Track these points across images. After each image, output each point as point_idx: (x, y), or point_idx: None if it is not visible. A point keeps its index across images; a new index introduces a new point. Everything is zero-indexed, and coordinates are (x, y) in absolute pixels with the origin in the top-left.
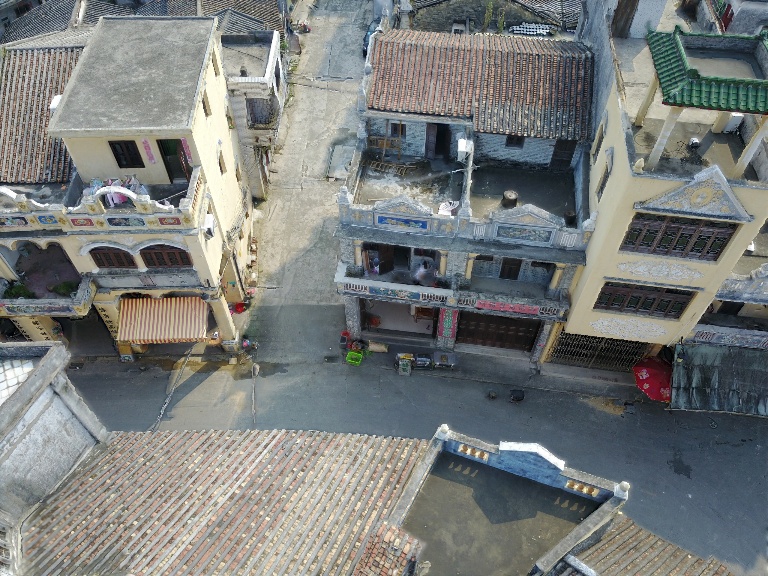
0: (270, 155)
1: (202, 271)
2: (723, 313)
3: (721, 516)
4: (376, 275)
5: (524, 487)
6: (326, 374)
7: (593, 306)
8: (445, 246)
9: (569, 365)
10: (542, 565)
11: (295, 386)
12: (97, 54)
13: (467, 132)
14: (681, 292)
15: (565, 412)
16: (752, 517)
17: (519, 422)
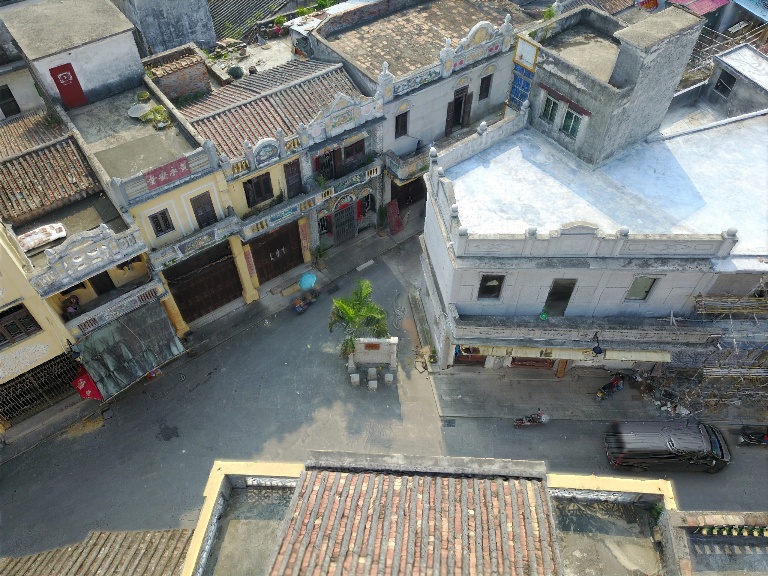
0: None
1: None
2: (103, 293)
3: (213, 448)
4: None
5: None
6: None
7: None
8: None
9: (32, 416)
10: None
11: None
12: None
13: None
14: (12, 310)
15: (47, 461)
16: (237, 430)
17: (3, 505)
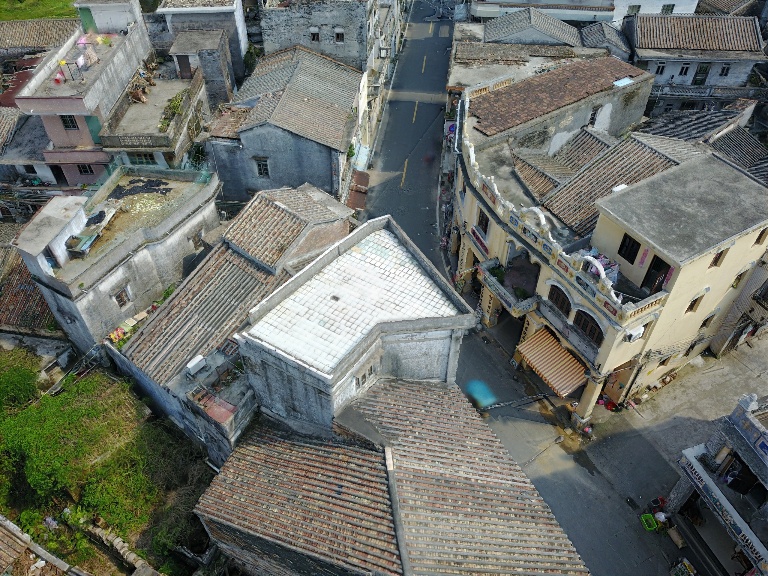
0: (760, 331)
1: (602, 356)
2: None
3: None
4: (724, 483)
5: None
6: (617, 508)
7: None
8: None
9: None
10: None
11: (587, 489)
12: (679, 175)
13: None
14: None
15: None
16: None
17: None
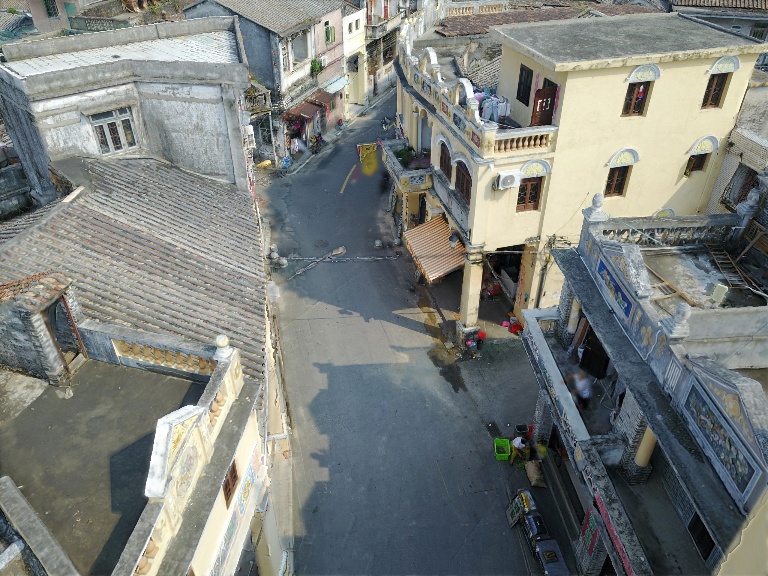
0: None
1: (471, 216)
2: None
3: None
4: (577, 363)
5: None
6: (470, 429)
7: None
8: (618, 355)
9: None
10: (0, 483)
11: (440, 404)
12: (619, 22)
13: None
14: None
15: None
16: None
17: None
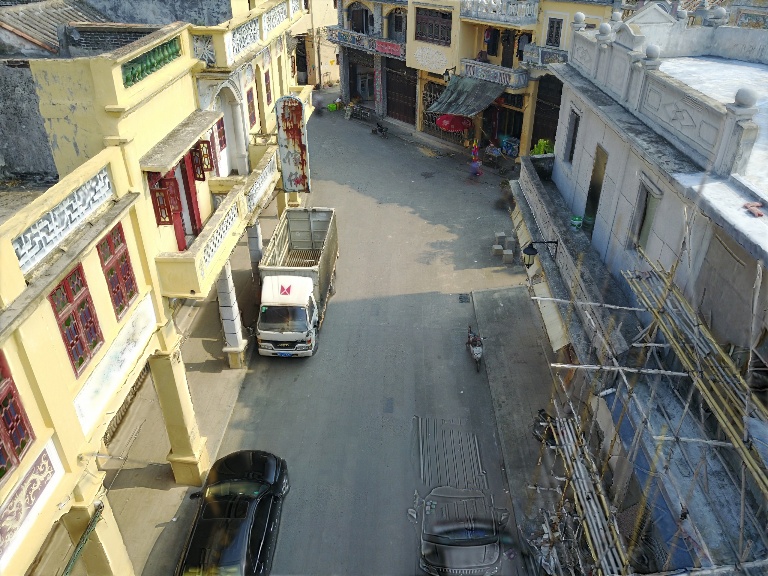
0: None
1: None
2: None
3: (417, 190)
4: None
5: None
6: None
7: (414, 35)
8: None
9: (432, 135)
10: None
11: None
12: None
13: None
14: (449, 17)
15: (401, 147)
16: None
17: (372, 141)
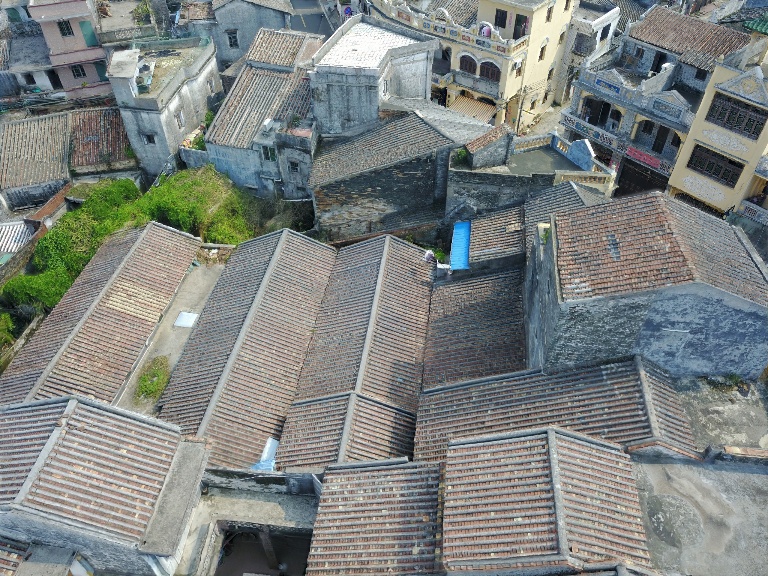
0: None
1: (502, 86)
2: None
3: None
4: None
5: (575, 168)
6: None
7: (687, 164)
8: (623, 105)
9: None
10: (557, 171)
11: None
12: None
13: (676, 62)
14: (738, 165)
15: None
16: None
17: None
